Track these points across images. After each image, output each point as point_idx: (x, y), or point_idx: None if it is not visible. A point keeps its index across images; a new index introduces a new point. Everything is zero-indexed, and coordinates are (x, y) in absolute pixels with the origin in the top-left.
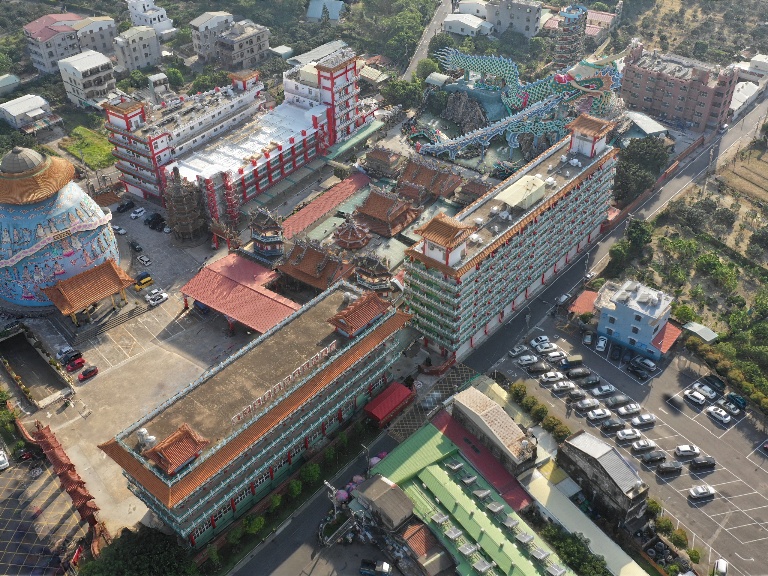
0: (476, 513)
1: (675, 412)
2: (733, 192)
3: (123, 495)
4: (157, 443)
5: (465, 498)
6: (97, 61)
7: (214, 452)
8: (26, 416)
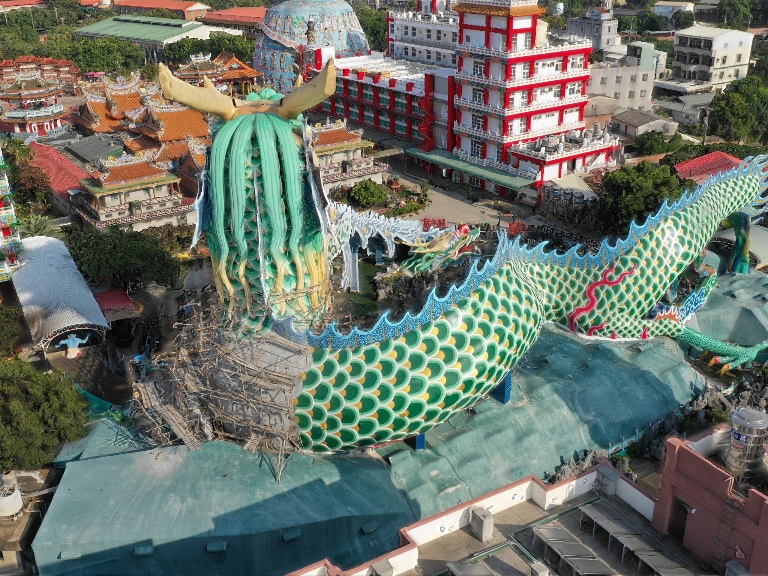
0: None
1: None
2: None
3: (7, 105)
4: None
5: None
6: (707, 33)
7: None
8: None
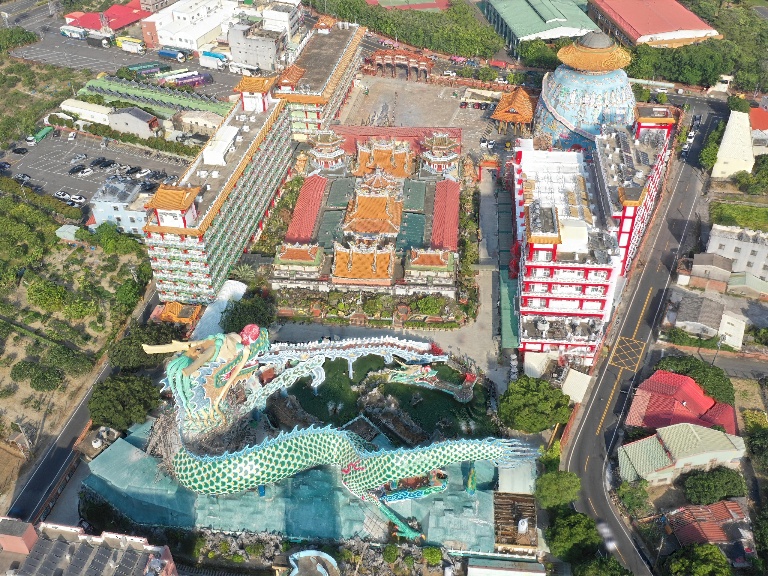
0: (198, 106)
1: (93, 190)
2: (2, 432)
3: None
4: (340, 29)
5: (206, 108)
6: None
7: (313, 34)
8: (468, 87)
